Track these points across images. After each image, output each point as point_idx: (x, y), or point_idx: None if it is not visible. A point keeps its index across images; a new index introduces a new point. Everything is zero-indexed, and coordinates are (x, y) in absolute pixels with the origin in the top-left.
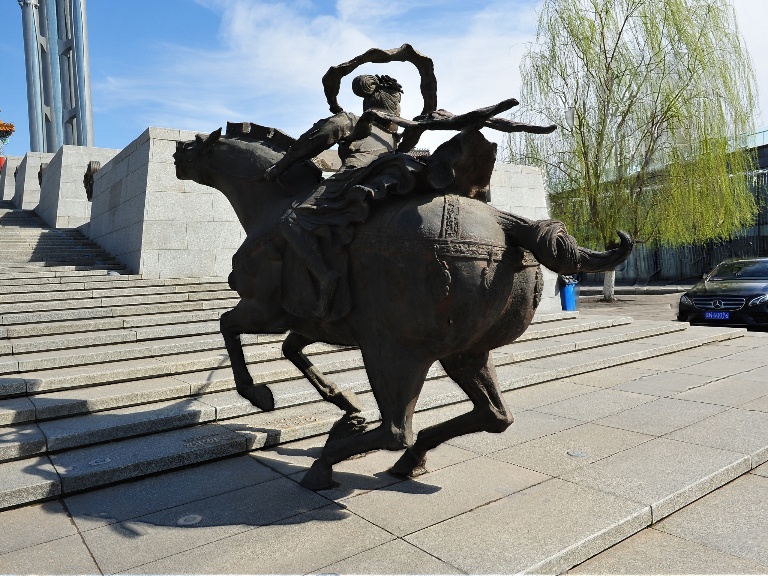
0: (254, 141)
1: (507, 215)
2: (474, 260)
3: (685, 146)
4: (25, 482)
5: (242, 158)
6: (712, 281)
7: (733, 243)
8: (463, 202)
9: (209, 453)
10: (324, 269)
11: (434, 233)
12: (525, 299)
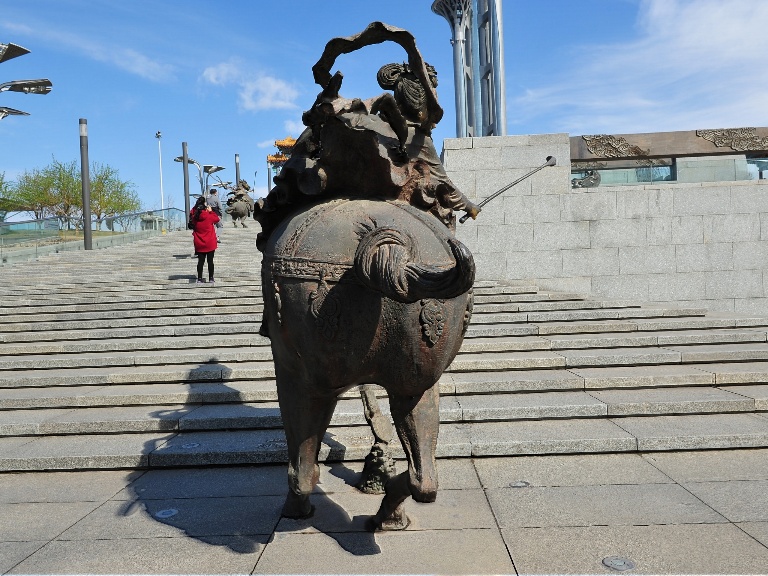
0: None
1: (372, 221)
2: (301, 281)
3: None
4: (129, 451)
5: None
6: None
7: None
8: (339, 208)
9: (271, 456)
10: None
11: (279, 249)
12: (404, 332)
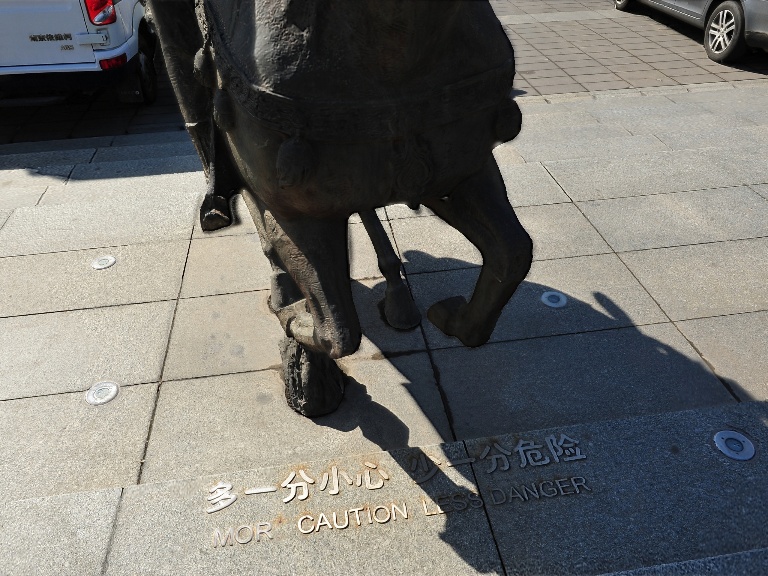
0: None
1: None
2: None
3: None
4: None
5: None
6: None
7: None
8: None
9: None
10: None
11: None
12: None
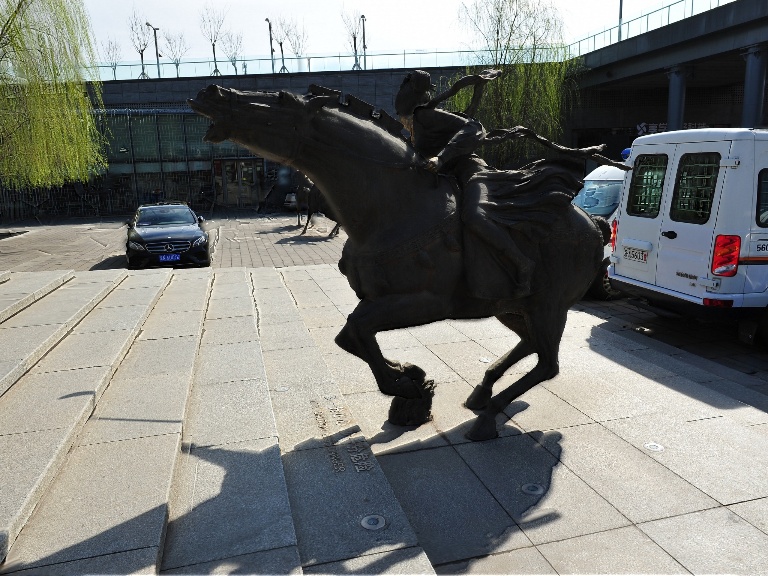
0: (363, 118)
1: None
2: None
3: (25, 81)
4: (418, 571)
5: (368, 138)
6: (139, 226)
7: (75, 186)
8: None
9: None
10: (524, 256)
11: None
12: None
